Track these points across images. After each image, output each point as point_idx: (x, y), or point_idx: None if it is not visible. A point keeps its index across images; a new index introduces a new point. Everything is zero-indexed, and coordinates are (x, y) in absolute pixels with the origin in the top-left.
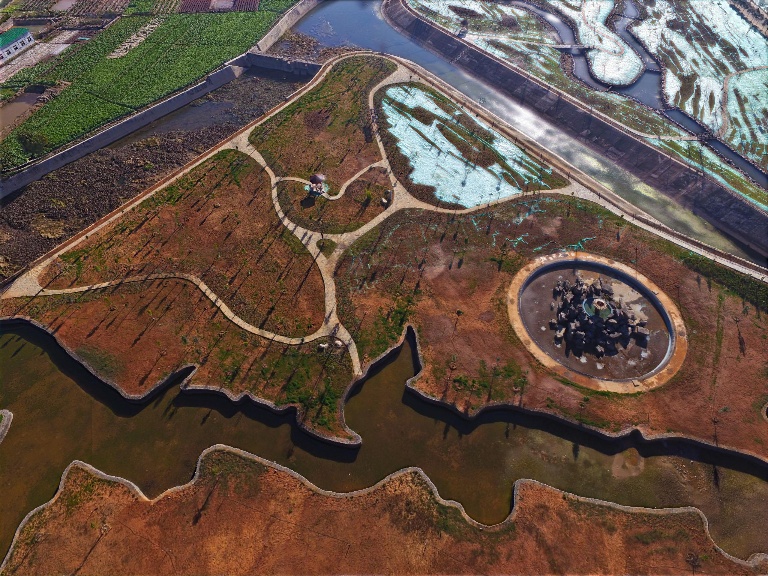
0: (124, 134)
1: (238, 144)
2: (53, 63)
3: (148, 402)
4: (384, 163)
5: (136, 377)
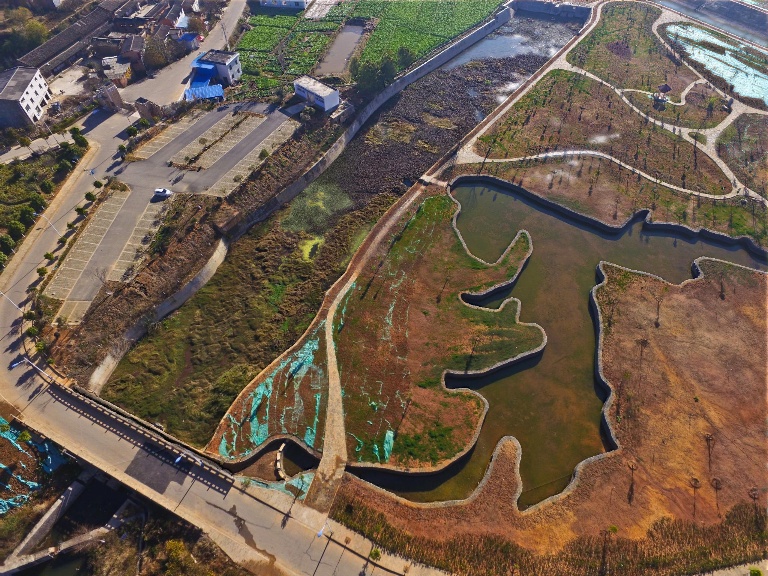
0: (448, 59)
1: (562, 65)
2: (352, 3)
3: (623, 232)
4: (704, 81)
5: (608, 214)
